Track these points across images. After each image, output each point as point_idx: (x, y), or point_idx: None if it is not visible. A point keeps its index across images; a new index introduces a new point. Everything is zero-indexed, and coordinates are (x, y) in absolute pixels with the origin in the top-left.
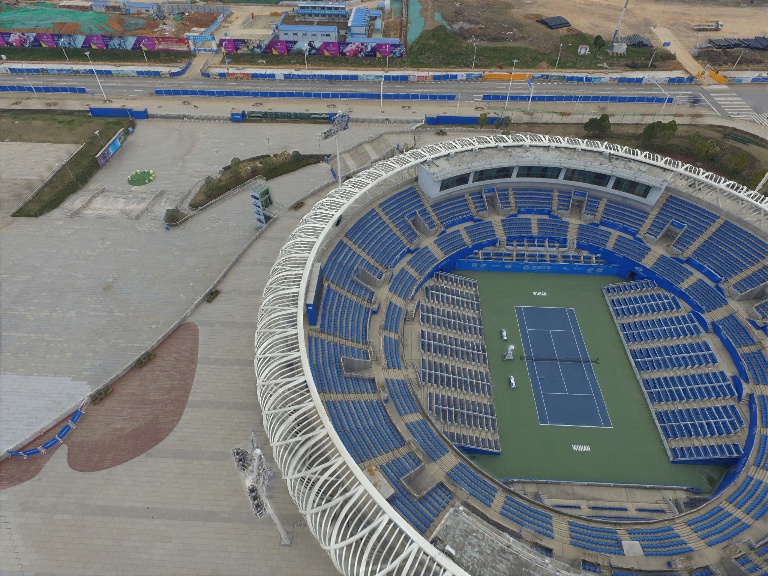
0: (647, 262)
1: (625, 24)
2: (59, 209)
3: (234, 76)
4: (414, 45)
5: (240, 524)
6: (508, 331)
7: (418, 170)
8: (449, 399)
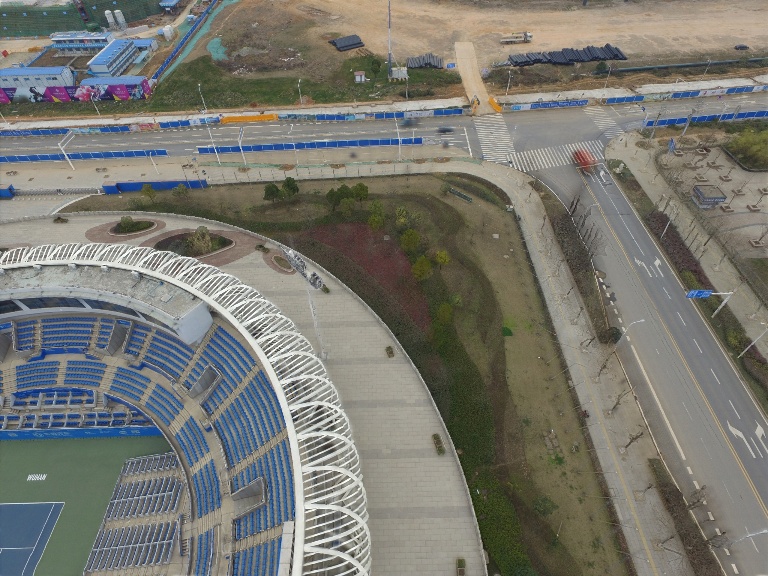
0: (175, 426)
1: (428, 40)
2: None
3: None
4: (163, 83)
5: None
6: None
7: None
8: None
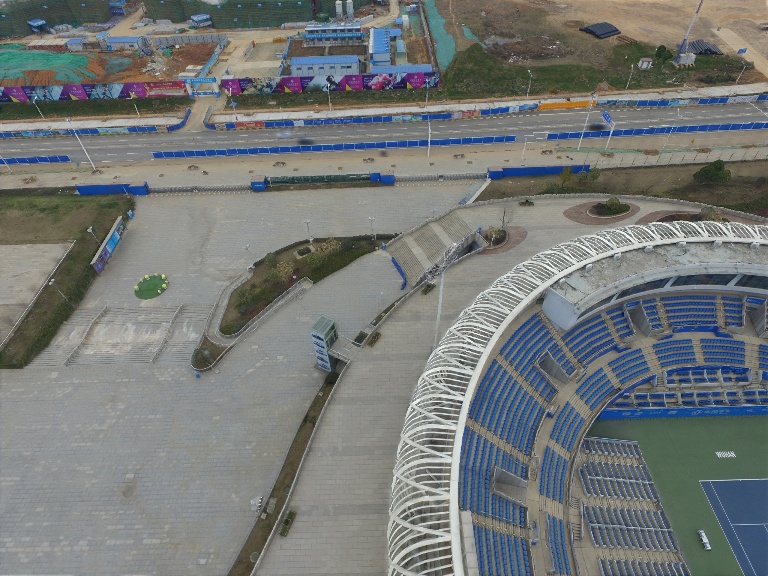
0: None
1: (681, 27)
2: (50, 349)
3: (245, 126)
4: (449, 71)
5: None
6: (706, 531)
7: (546, 294)
8: None
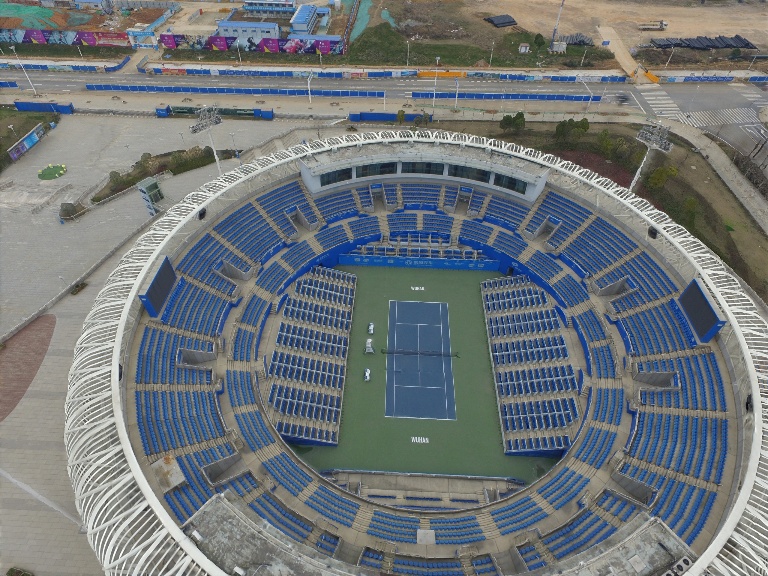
0: (523, 258)
1: (571, 23)
2: None
3: (169, 72)
4: (355, 42)
5: (45, 512)
6: (377, 325)
7: (299, 165)
8: (294, 391)
